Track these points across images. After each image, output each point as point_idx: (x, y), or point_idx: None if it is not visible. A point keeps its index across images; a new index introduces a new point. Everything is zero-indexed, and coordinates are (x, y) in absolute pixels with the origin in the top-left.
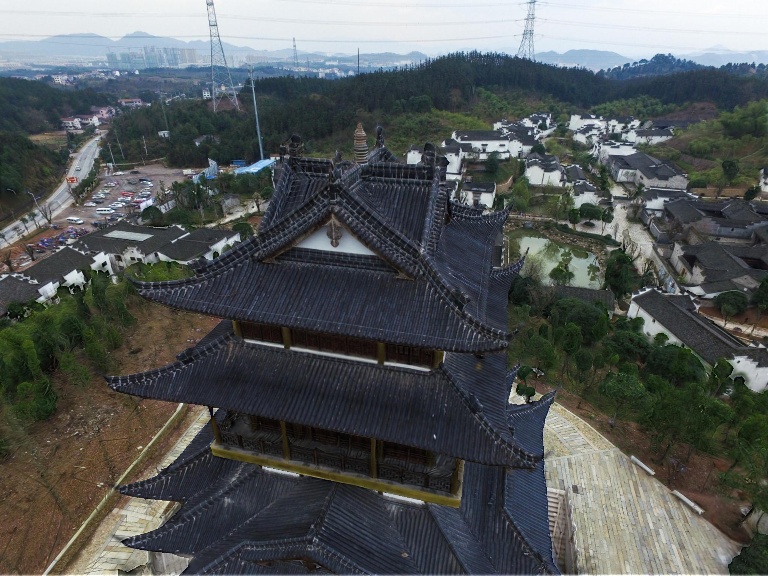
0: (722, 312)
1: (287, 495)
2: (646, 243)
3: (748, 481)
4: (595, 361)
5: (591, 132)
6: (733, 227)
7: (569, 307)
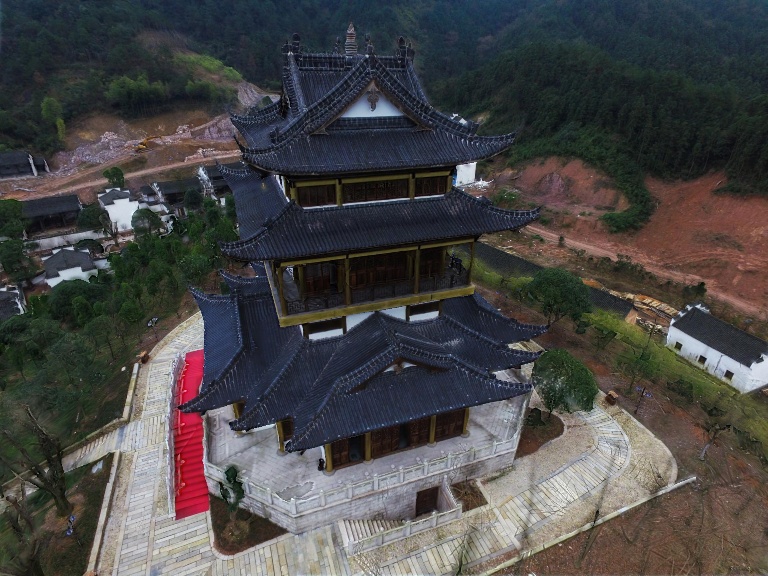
0: None
1: None
2: None
3: None
4: (110, 309)
5: None
6: None
7: None
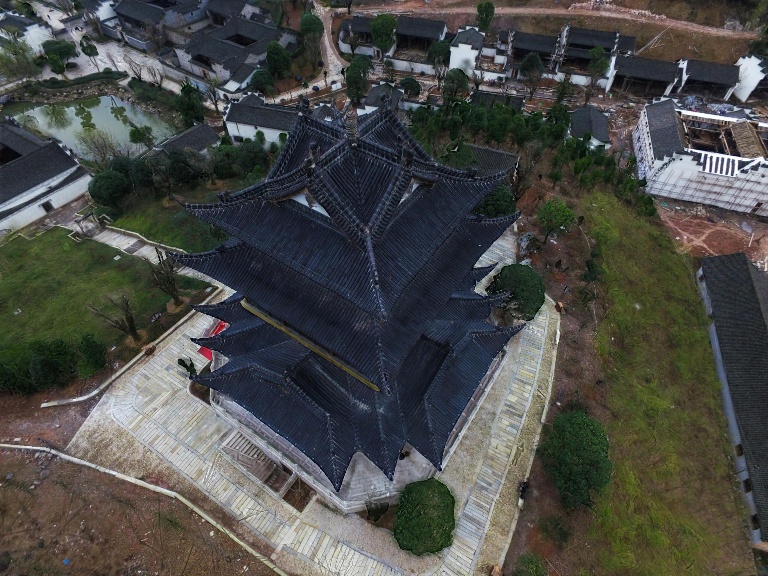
0: (268, 93)
1: None
2: (142, 60)
3: None
4: None
5: None
6: (191, 11)
7: (225, 157)
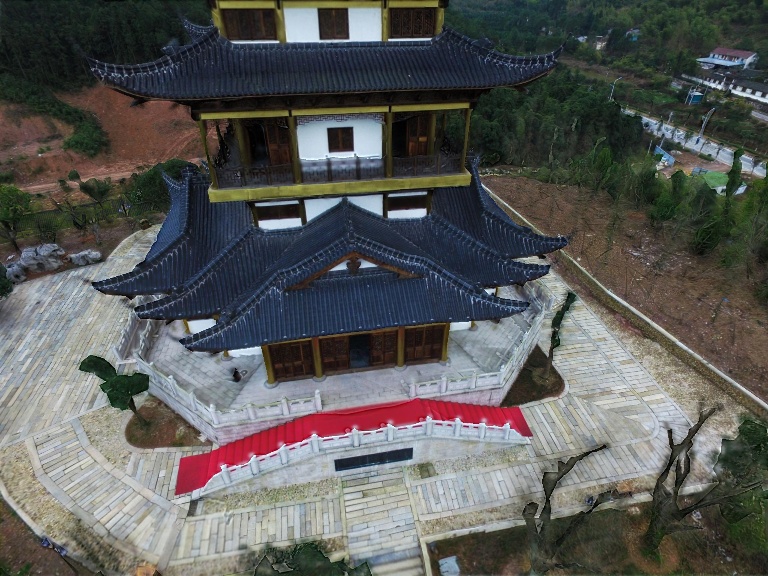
0: None
1: None
2: None
3: None
4: None
5: None
6: None
7: None
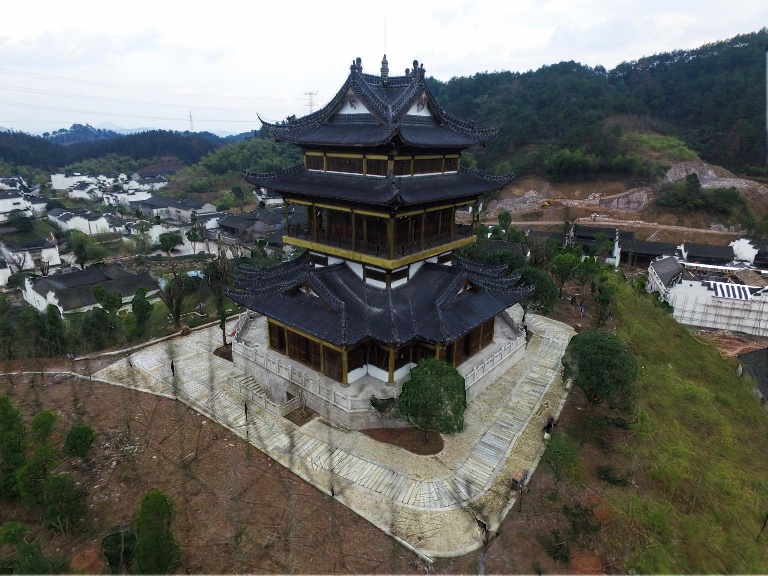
0: None
1: (411, 293)
2: None
3: (471, 246)
4: None
5: (90, 187)
6: (274, 224)
7: None
